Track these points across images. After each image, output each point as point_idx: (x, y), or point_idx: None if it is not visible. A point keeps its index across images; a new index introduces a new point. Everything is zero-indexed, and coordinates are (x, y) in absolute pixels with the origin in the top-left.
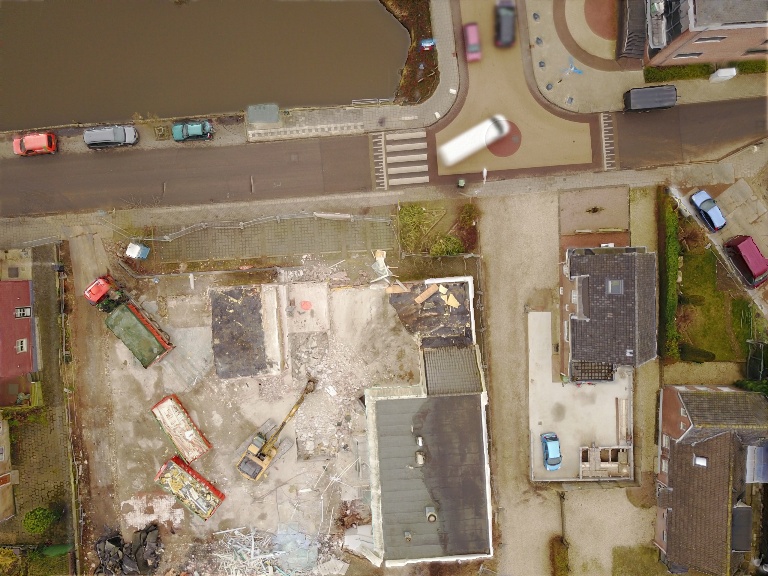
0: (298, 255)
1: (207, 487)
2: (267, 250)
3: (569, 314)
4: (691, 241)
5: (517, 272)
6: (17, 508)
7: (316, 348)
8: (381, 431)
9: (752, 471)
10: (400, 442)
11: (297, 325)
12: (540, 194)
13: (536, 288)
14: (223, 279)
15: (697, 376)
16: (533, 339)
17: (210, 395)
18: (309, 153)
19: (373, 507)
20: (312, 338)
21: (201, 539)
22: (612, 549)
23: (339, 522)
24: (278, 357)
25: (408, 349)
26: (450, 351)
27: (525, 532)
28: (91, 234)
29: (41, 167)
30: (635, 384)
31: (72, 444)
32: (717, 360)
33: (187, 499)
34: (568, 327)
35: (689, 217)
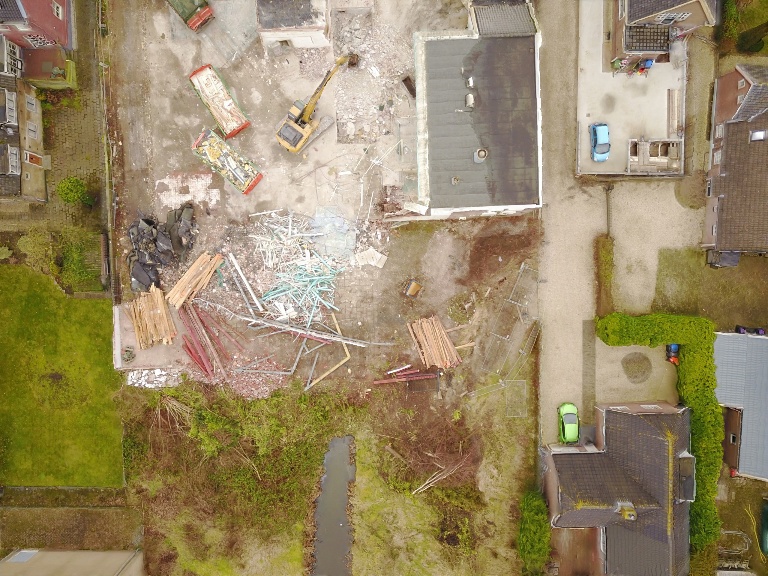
0: None
1: None
2: None
3: None
4: None
5: None
6: (49, 195)
7: (359, 30)
8: (430, 74)
9: None
10: (449, 85)
11: (340, 1)
12: None
13: None
14: None
15: None
16: (584, 26)
17: (249, 71)
18: None
19: (419, 155)
20: (355, 21)
21: (237, 221)
22: (658, 251)
23: (379, 207)
24: (323, 7)
25: None
26: (502, 7)
27: (569, 230)
28: None
29: None
30: (688, 77)
31: (107, 121)
32: None
33: (225, 169)
34: None
35: None
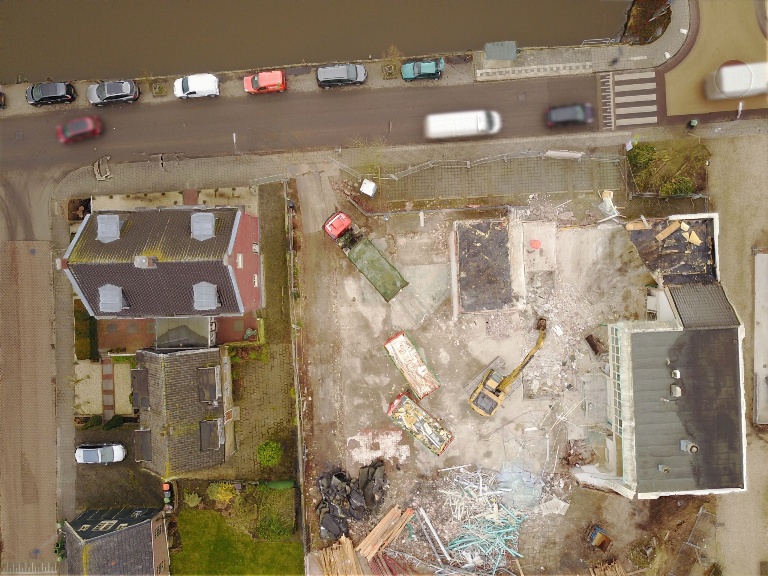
0: (524, 195)
1: None
2: (493, 189)
3: None
4: None
5: (745, 214)
6: (237, 444)
7: (541, 288)
8: (635, 364)
9: None
10: (655, 375)
11: (526, 264)
12: None
13: (764, 230)
14: (453, 217)
15: None
16: (760, 281)
17: (438, 333)
18: (537, 93)
19: (625, 440)
20: (536, 278)
21: (426, 476)
22: None
23: (564, 461)
24: (524, 291)
25: (634, 290)
26: (696, 287)
27: None
28: (318, 172)
29: (268, 105)
30: None
31: (298, 380)
32: None
33: (420, 434)
34: None
35: None
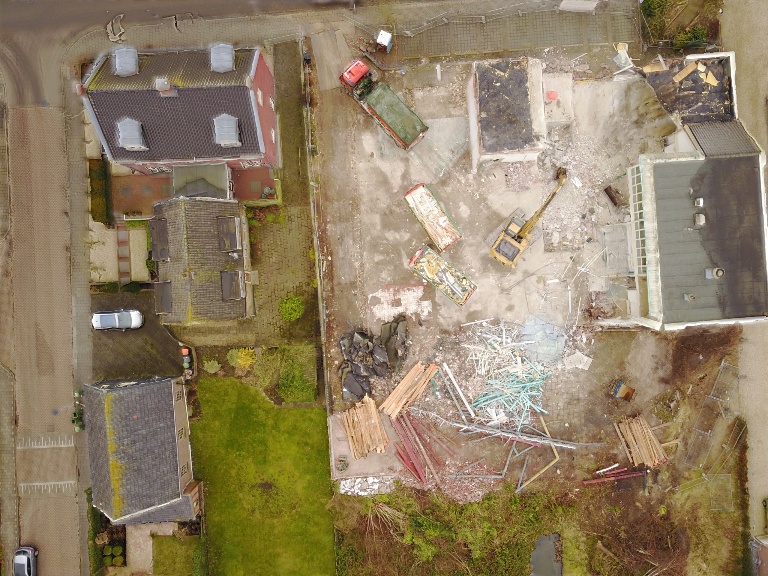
0: (540, 49)
1: None
2: (509, 44)
3: None
4: None
5: (758, 64)
6: (256, 309)
7: (559, 141)
8: (658, 194)
9: None
10: (678, 205)
11: None
12: None
13: None
14: None
15: None
16: None
17: (457, 186)
18: None
19: (649, 272)
20: (554, 132)
21: (449, 331)
22: None
23: (586, 313)
24: (544, 130)
25: (651, 141)
26: (715, 124)
27: (766, 327)
28: (333, 30)
29: None
30: None
31: (318, 238)
32: None
33: (443, 284)
34: None
35: None
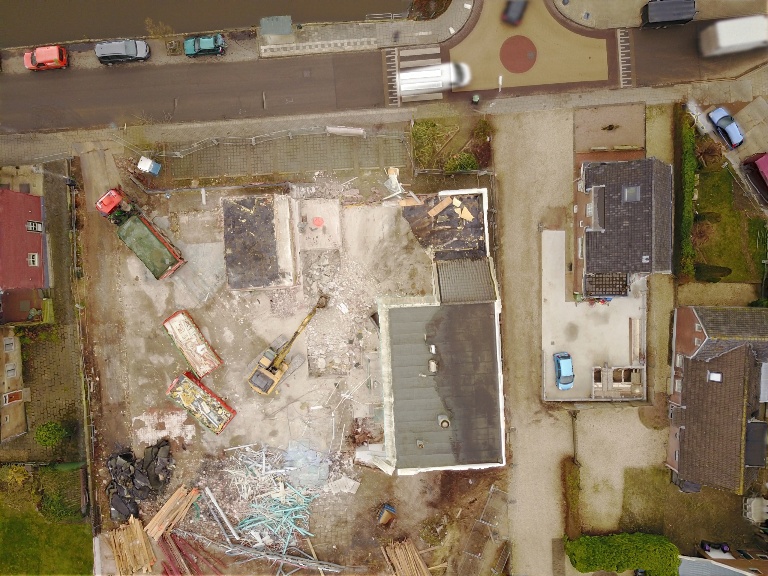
0: (310, 172)
1: (219, 402)
2: (279, 167)
3: (584, 227)
4: (708, 156)
5: (531, 190)
6: (29, 426)
7: (328, 266)
8: (394, 339)
9: (766, 390)
10: (413, 350)
11: (309, 241)
12: (555, 111)
13: (550, 206)
14: (235, 194)
15: (711, 297)
16: (546, 258)
17: (222, 311)
18: (322, 69)
19: (385, 416)
20: (324, 256)
21: (212, 455)
22: (624, 471)
23: (350, 439)
24: (290, 267)
25: (420, 267)
26: (463, 263)
27: (536, 453)
28: (102, 150)
29: (52, 82)
30: (649, 304)
31: (84, 360)
32: (732, 281)
33: (199, 413)
34: (582, 242)
35: (706, 135)
